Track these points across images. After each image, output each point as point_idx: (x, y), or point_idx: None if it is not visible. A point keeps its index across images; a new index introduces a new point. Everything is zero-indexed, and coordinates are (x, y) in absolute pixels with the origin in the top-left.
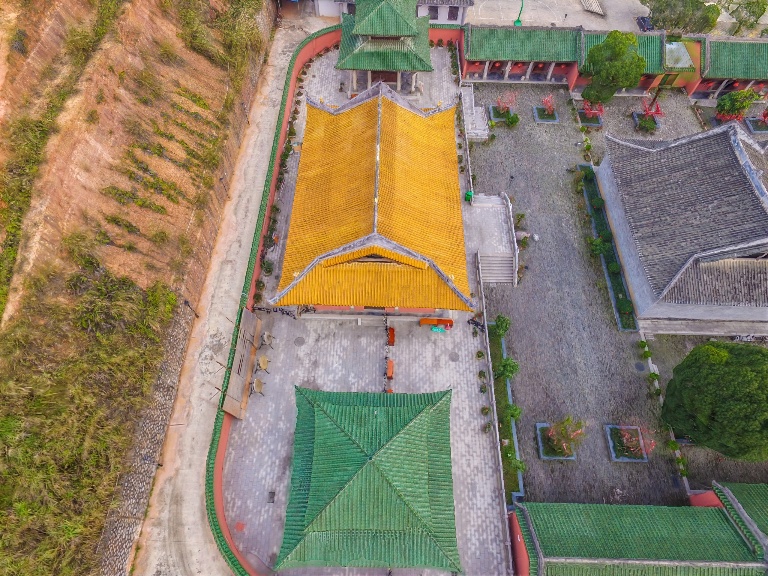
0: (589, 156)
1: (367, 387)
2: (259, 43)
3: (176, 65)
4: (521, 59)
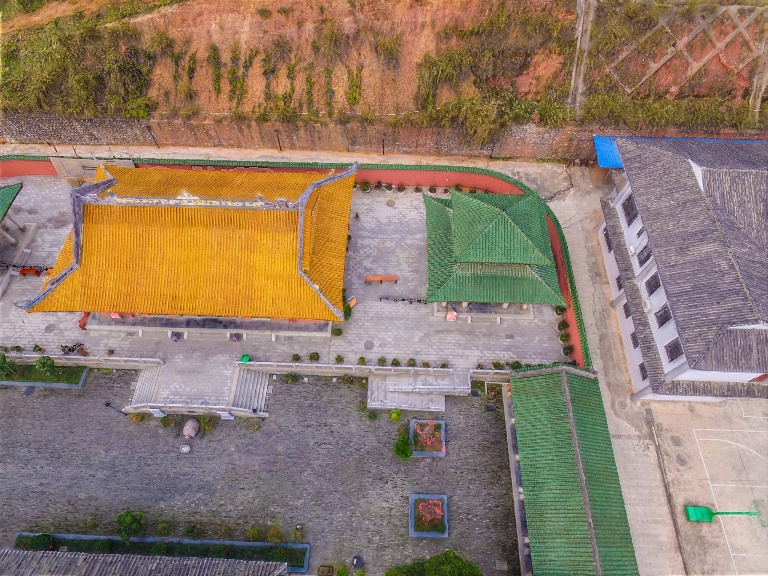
0: (329, 575)
1: (52, 258)
2: (473, 130)
3: (384, 62)
4: (522, 466)
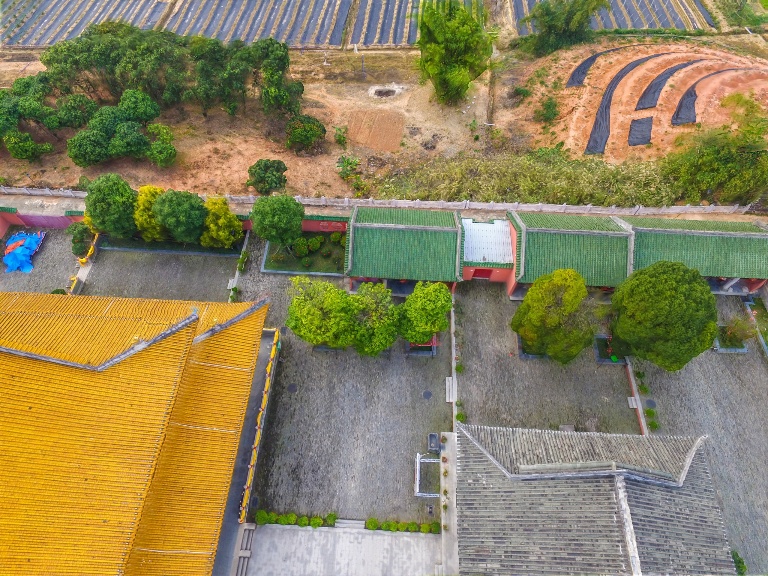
0: None
1: None
2: None
3: None
4: None
